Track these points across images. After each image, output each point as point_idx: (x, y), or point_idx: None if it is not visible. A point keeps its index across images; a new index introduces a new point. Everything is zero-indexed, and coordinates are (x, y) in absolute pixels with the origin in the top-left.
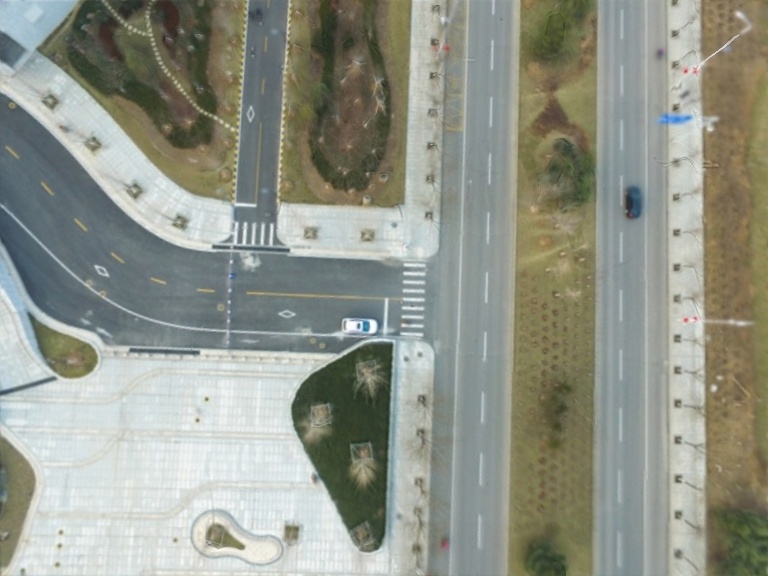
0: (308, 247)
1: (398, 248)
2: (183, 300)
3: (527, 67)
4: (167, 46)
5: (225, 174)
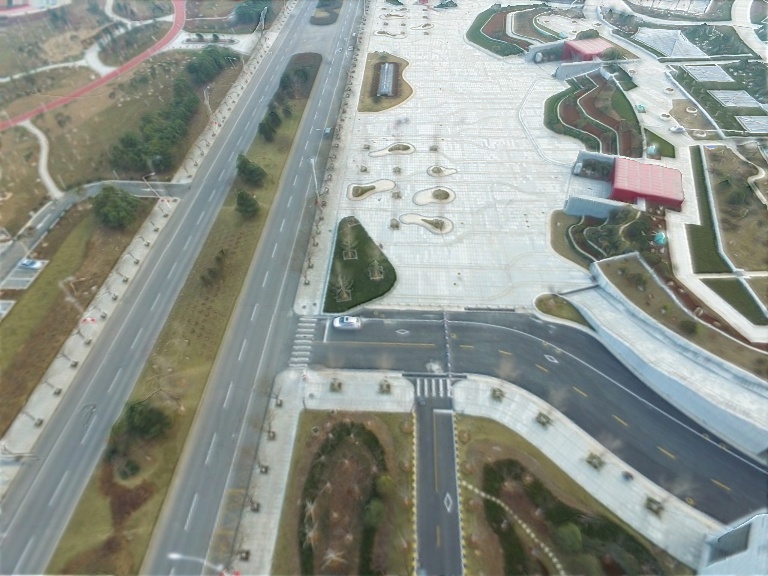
0: (387, 378)
1: (311, 378)
2: (483, 340)
3: (130, 570)
4: None
5: (465, 437)
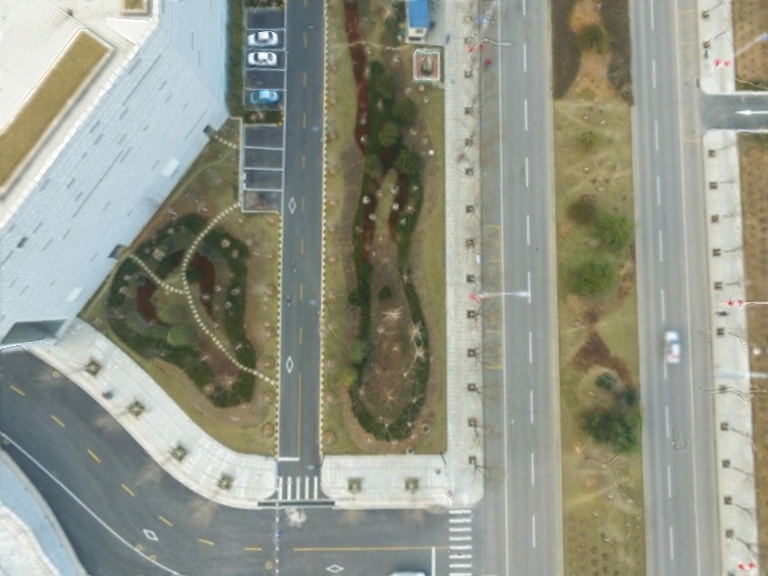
0: (353, 499)
1: (443, 495)
2: (231, 560)
3: (565, 299)
4: (204, 303)
5: (267, 429)
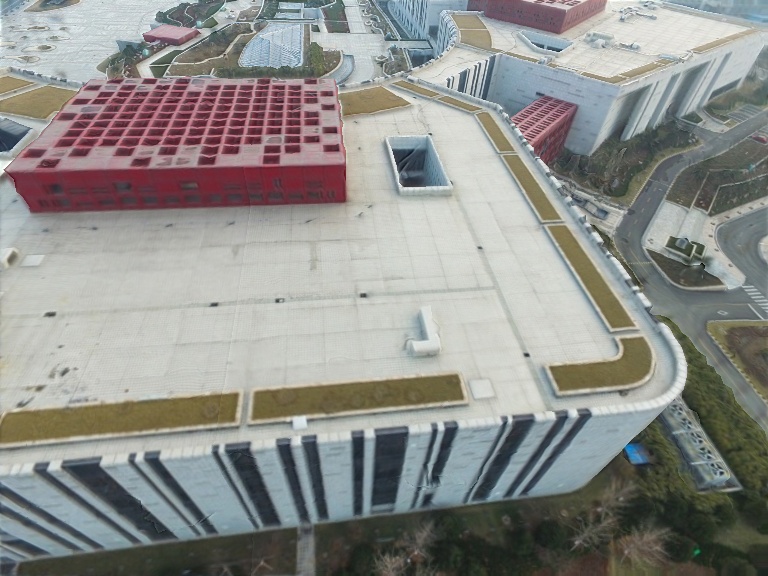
0: None
1: None
2: None
3: None
4: None
5: None
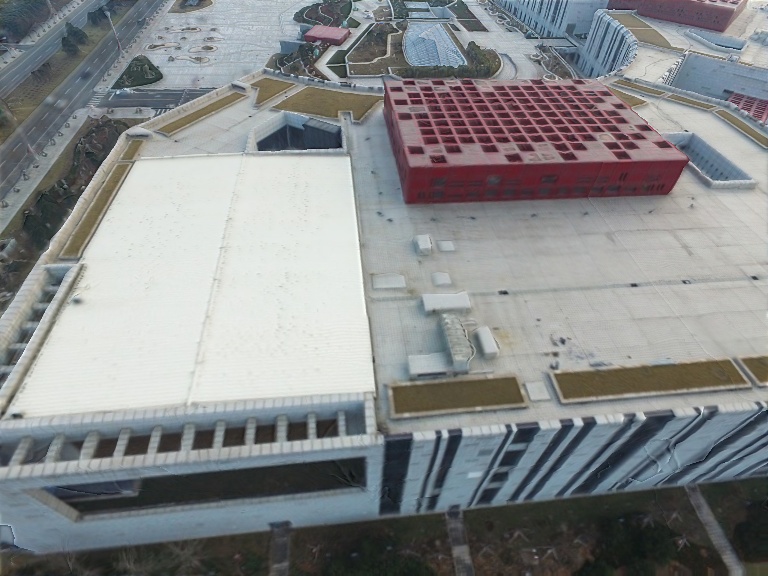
0: None
1: None
2: None
3: None
4: None
5: None
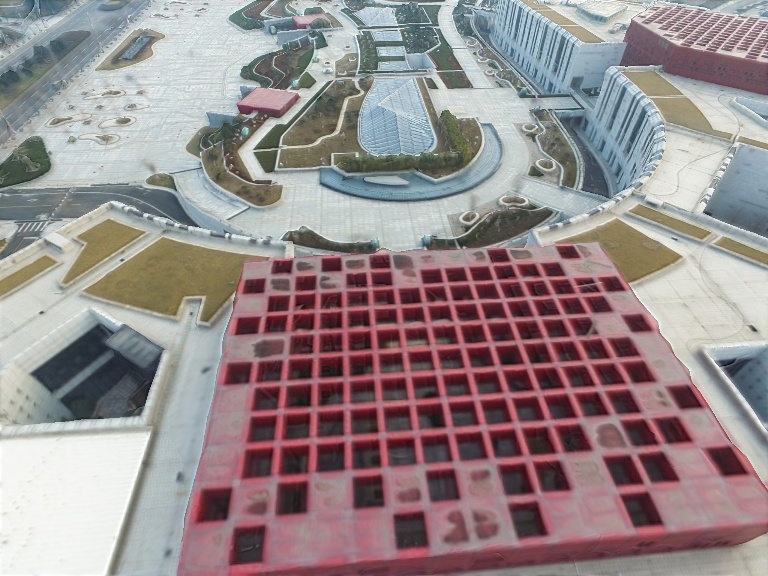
0: (2, 224)
1: None
2: (91, 201)
3: None
4: None
5: None
